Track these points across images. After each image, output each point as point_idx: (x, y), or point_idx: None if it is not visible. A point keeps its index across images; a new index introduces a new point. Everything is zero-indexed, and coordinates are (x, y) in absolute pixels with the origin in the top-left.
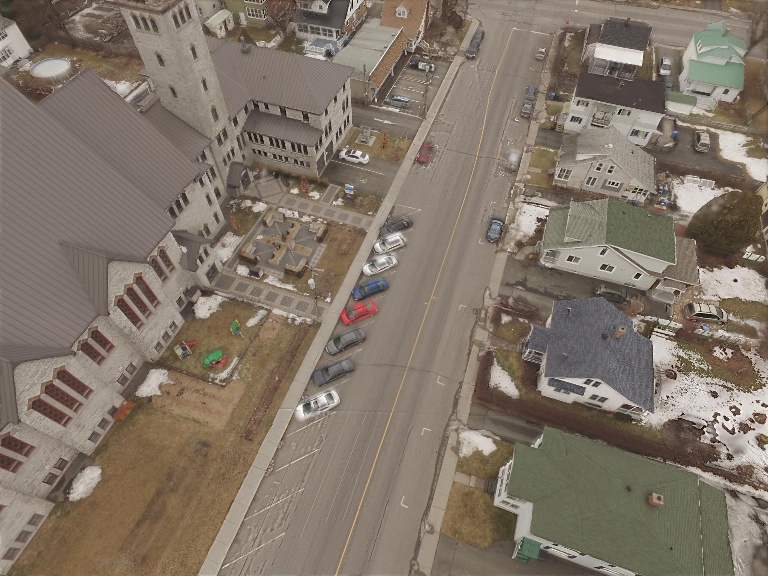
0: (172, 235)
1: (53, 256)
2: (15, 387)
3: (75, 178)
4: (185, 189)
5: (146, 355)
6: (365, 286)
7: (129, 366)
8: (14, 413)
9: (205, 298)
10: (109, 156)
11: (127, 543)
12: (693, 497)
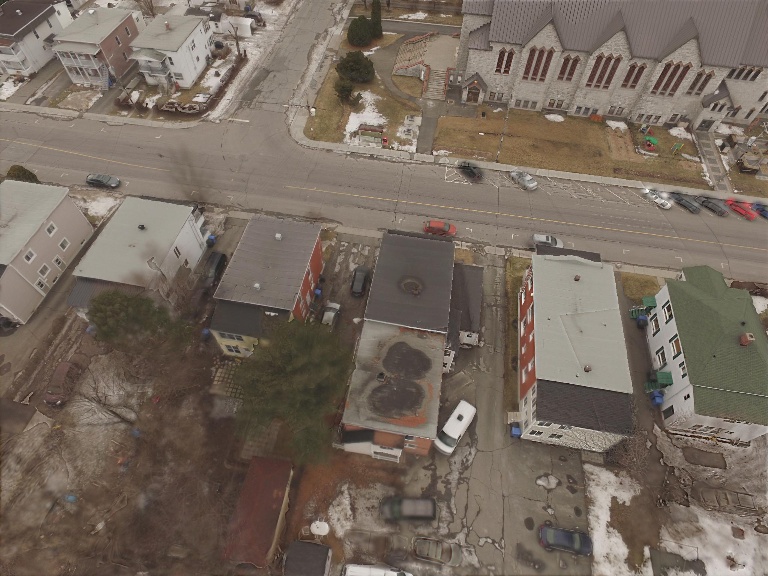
0: (725, 75)
1: (682, 19)
2: (611, 38)
3: (737, 1)
4: (764, 70)
5: (633, 112)
6: (767, 211)
7: (621, 109)
8: (596, 48)
9: (684, 130)
10: (761, 13)
11: (539, 140)
12: (765, 389)
